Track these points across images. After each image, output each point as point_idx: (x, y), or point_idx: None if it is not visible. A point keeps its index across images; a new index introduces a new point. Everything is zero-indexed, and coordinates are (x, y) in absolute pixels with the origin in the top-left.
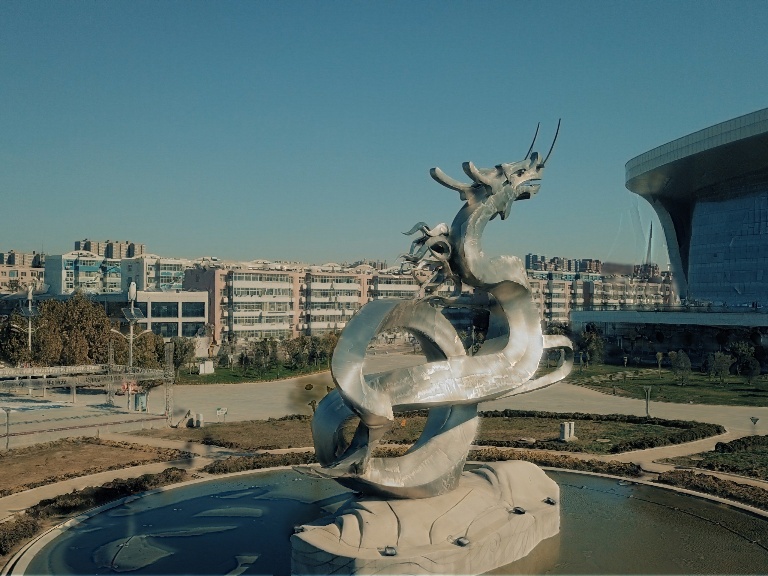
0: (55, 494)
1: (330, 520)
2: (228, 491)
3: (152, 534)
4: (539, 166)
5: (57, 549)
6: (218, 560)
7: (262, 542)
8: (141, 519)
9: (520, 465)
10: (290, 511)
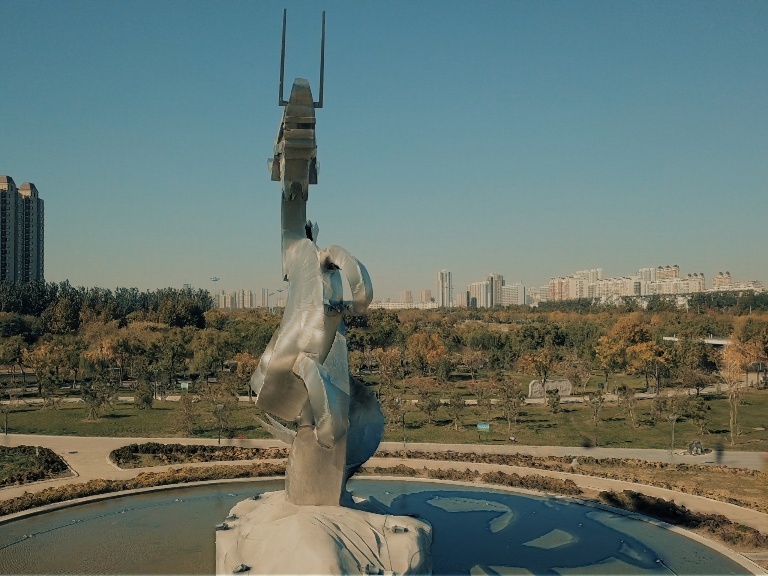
0: (692, 505)
1: None
2: (650, 550)
3: (513, 514)
4: (285, 104)
5: (504, 494)
6: (442, 531)
7: (484, 555)
8: (571, 518)
9: (294, 529)
10: (542, 562)
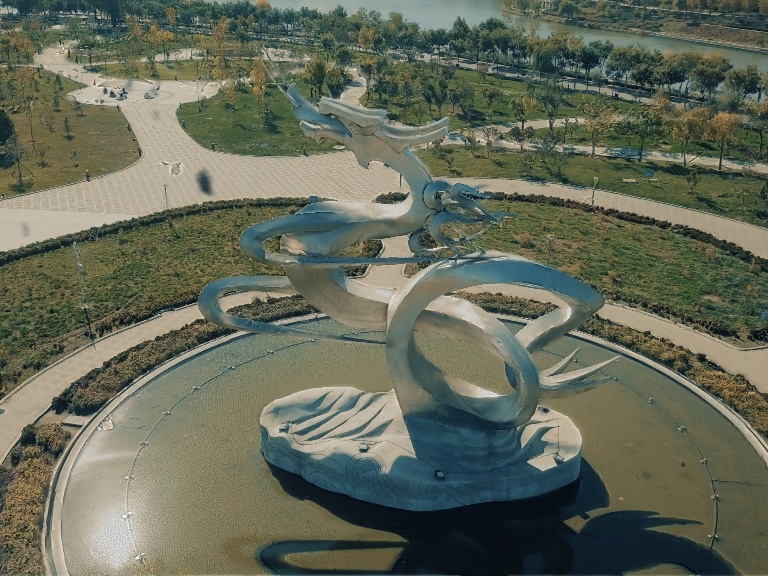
0: None
1: (506, 470)
2: None
3: None
4: None
5: None
6: None
7: None
8: None
9: None
10: None
